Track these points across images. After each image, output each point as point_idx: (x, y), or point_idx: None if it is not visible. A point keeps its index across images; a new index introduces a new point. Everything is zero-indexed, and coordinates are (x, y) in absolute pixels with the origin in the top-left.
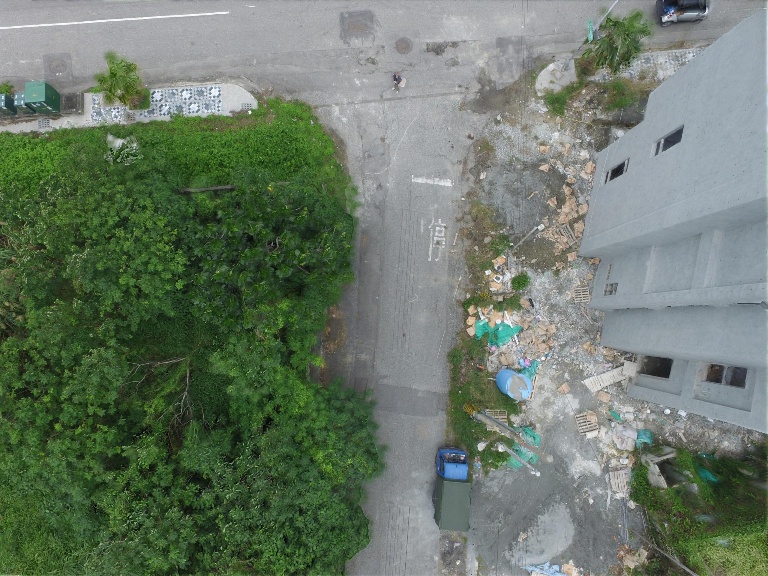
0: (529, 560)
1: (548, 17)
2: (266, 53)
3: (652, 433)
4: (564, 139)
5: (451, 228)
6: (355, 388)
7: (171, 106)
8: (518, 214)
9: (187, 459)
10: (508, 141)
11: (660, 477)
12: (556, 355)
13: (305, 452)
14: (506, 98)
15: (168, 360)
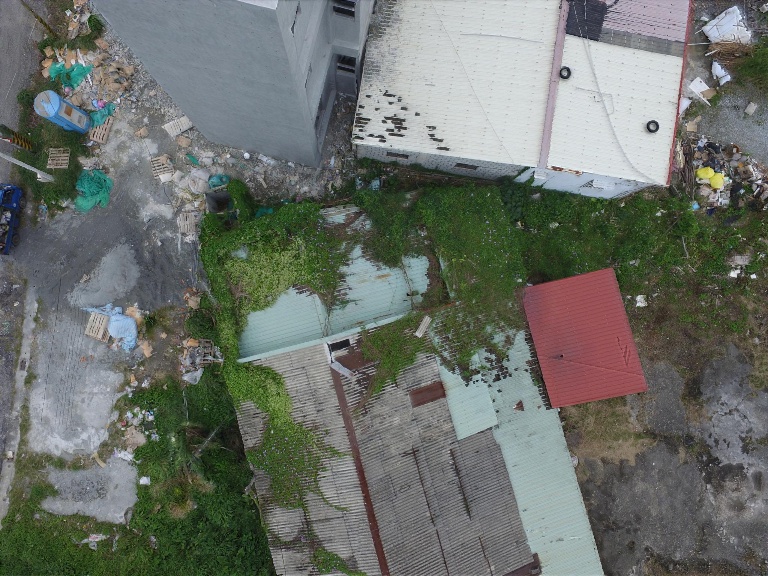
0: (84, 298)
1: None
2: None
3: (231, 178)
4: None
5: None
6: None
7: None
8: None
9: None
10: None
11: (205, 204)
12: (134, 98)
13: None
14: None
15: None
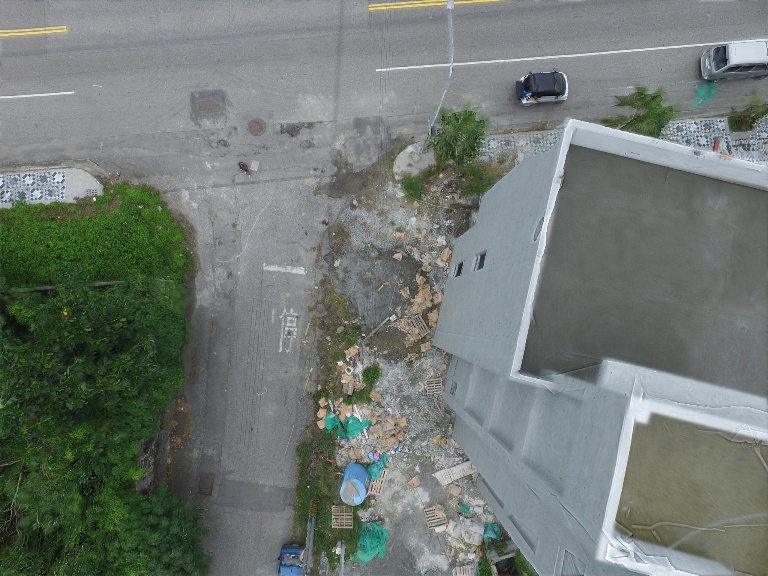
0: None
1: (408, 96)
2: (113, 135)
3: (501, 526)
4: (421, 225)
5: (303, 318)
6: (201, 484)
7: (13, 192)
8: (368, 306)
9: (6, 574)
10: (363, 227)
11: None
12: (407, 448)
13: (121, 570)
14: (363, 181)
15: (2, 463)
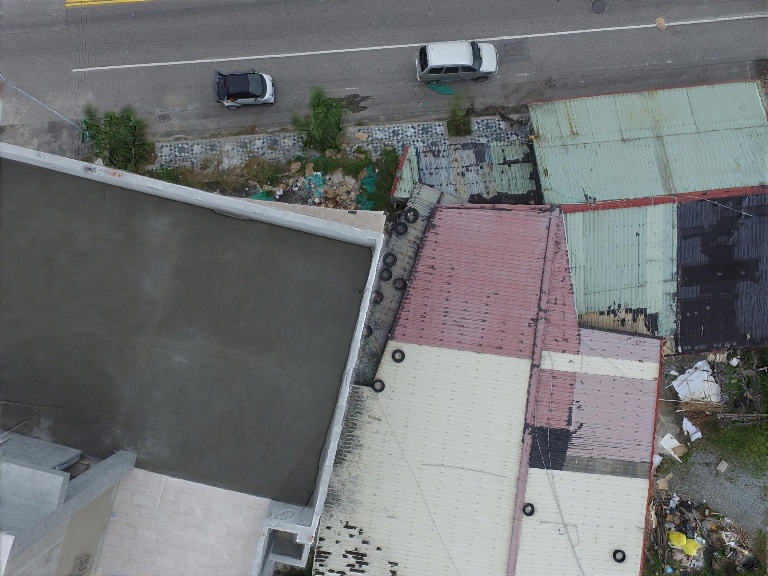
0: None
1: (107, 98)
2: None
3: None
4: None
5: None
6: None
7: None
8: None
9: None
10: None
11: None
12: None
13: None
14: None
15: None
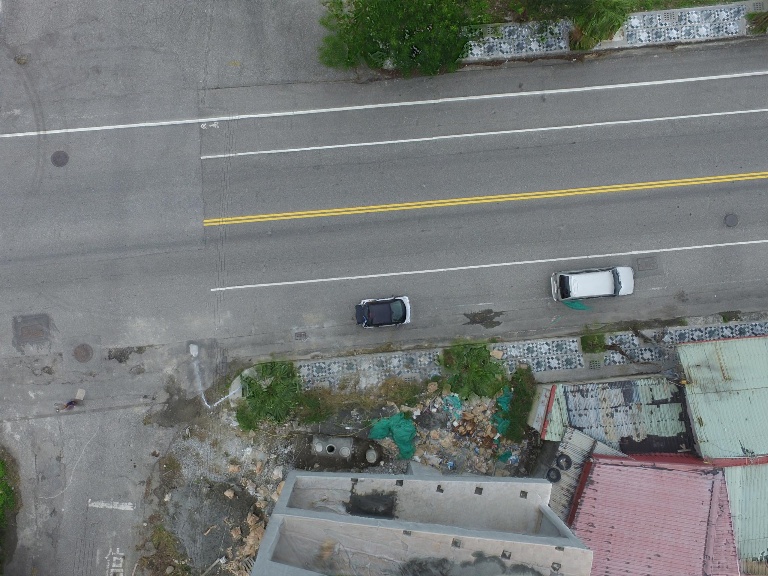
0: None
1: (245, 316)
2: None
3: None
4: (257, 455)
5: (130, 558)
6: None
7: None
8: (195, 550)
9: None
10: (196, 458)
11: None
12: None
13: None
14: (196, 409)
15: None
